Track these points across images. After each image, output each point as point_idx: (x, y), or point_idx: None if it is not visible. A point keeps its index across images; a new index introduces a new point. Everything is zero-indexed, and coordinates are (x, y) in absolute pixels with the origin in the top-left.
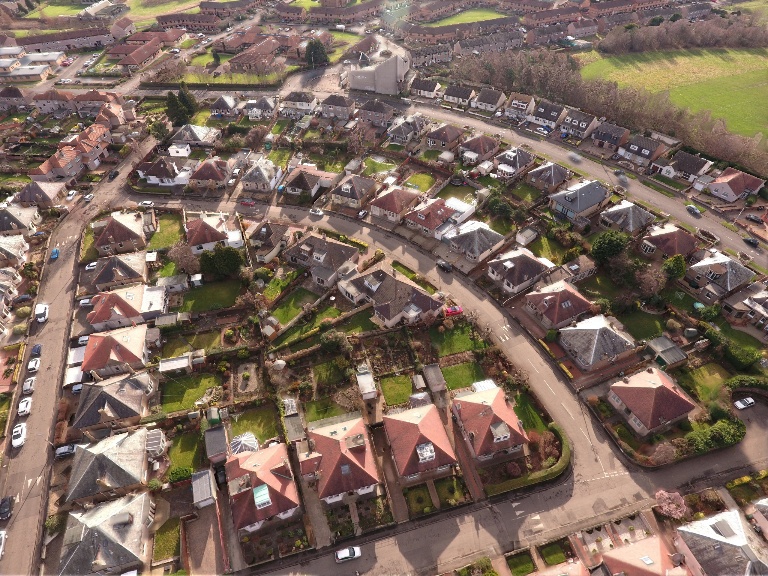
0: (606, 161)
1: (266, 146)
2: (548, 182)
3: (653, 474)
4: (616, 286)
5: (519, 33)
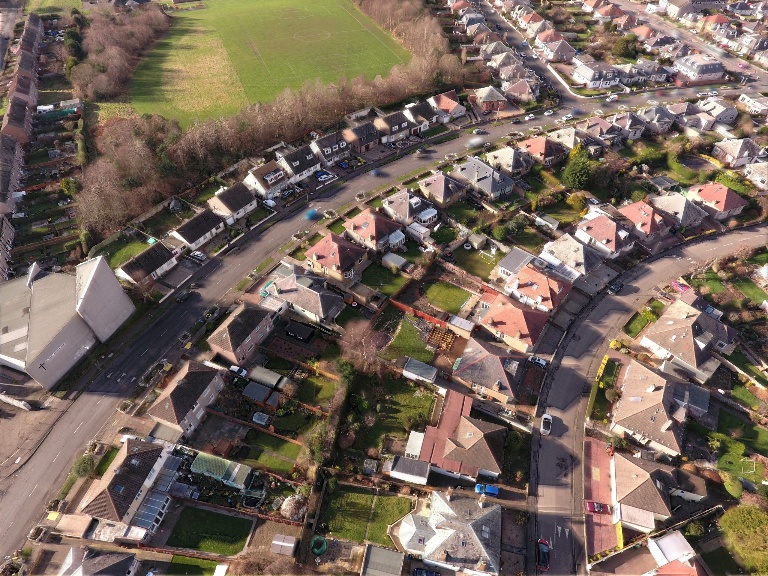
0: (398, 153)
1: (323, 548)
2: (462, 189)
3: (767, 215)
4: (595, 190)
5: (5, 137)
